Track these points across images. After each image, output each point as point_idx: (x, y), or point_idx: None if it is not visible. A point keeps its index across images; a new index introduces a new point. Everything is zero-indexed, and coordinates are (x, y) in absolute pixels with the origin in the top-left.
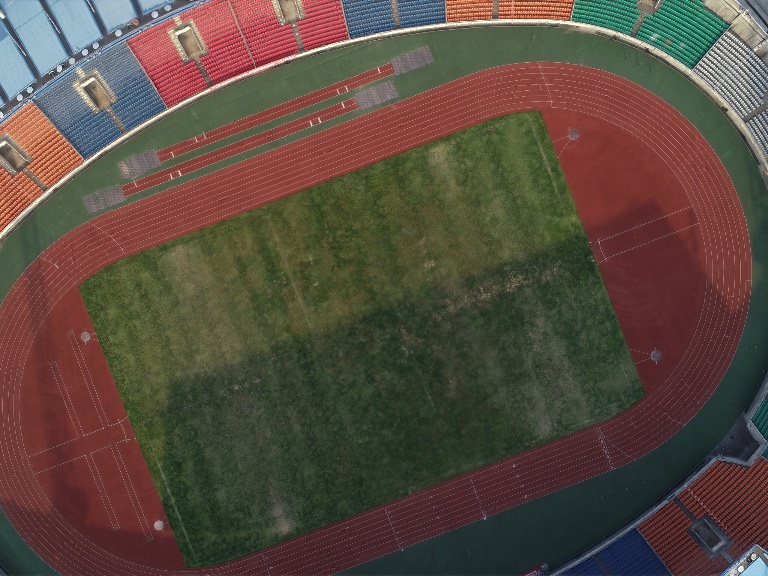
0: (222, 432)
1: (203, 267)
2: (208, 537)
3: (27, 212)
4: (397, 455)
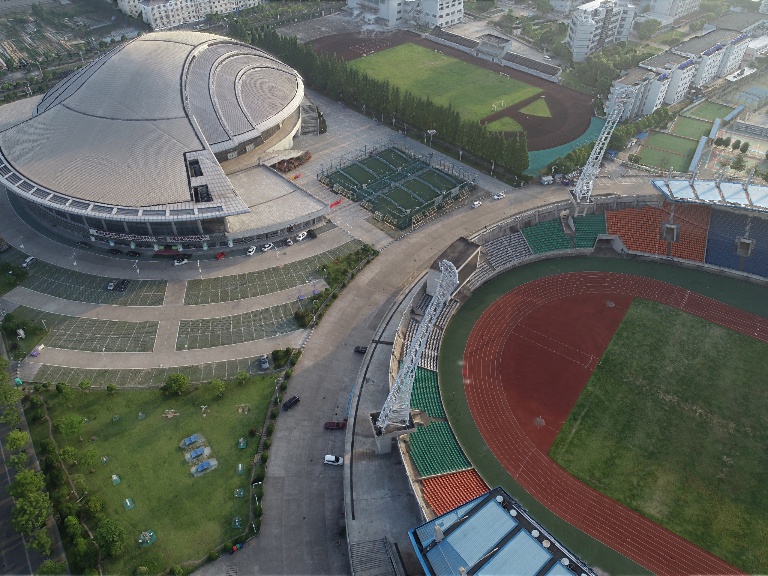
0: None
1: None
2: None
3: None
4: None
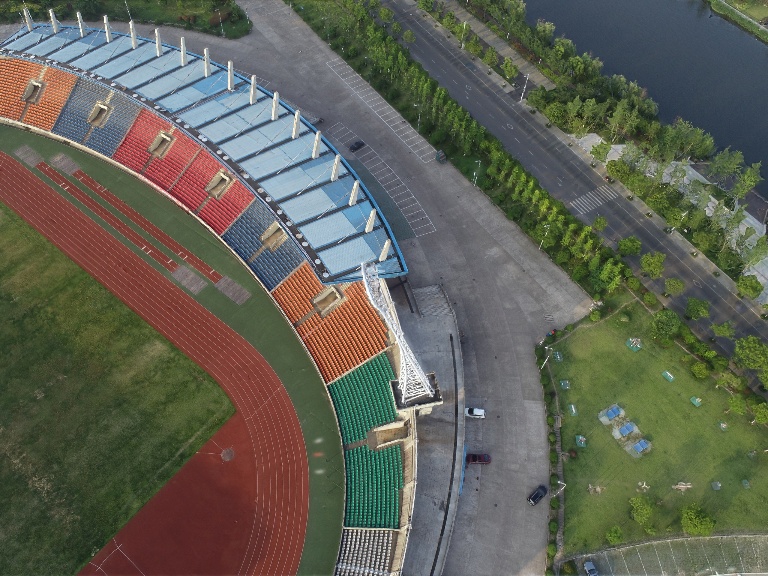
0: None
1: None
2: None
3: (4, 123)
4: None
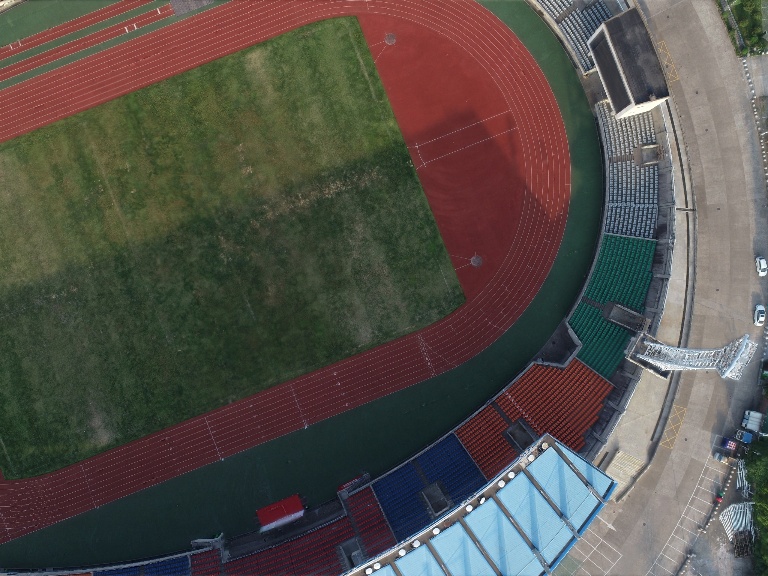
0: (39, 342)
1: (19, 175)
2: (26, 449)
3: None
4: (217, 364)
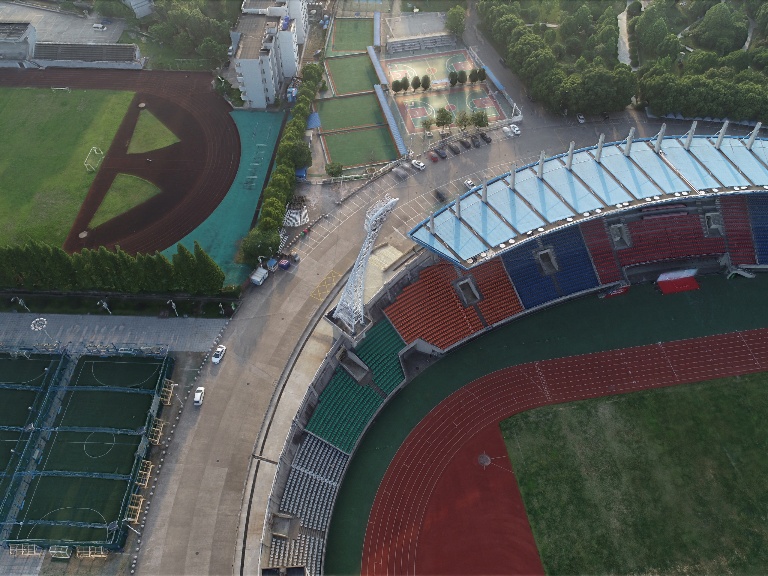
0: None
1: None
2: None
3: None
4: (759, 413)
